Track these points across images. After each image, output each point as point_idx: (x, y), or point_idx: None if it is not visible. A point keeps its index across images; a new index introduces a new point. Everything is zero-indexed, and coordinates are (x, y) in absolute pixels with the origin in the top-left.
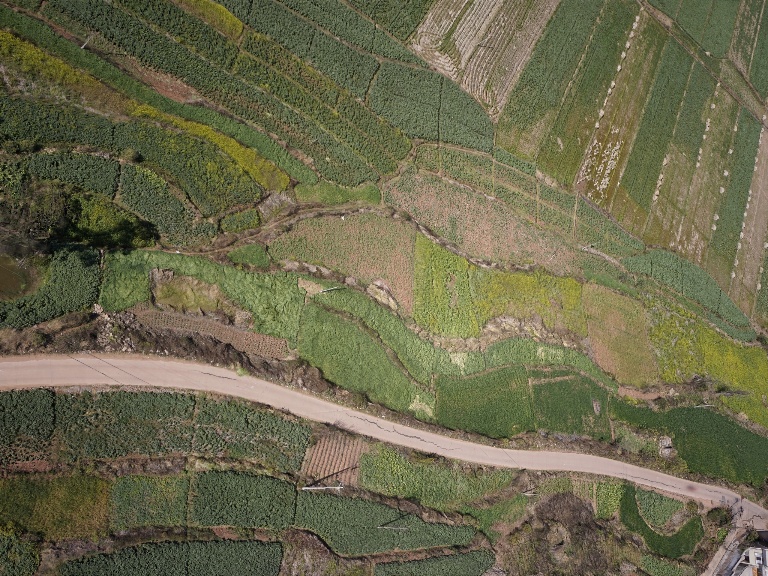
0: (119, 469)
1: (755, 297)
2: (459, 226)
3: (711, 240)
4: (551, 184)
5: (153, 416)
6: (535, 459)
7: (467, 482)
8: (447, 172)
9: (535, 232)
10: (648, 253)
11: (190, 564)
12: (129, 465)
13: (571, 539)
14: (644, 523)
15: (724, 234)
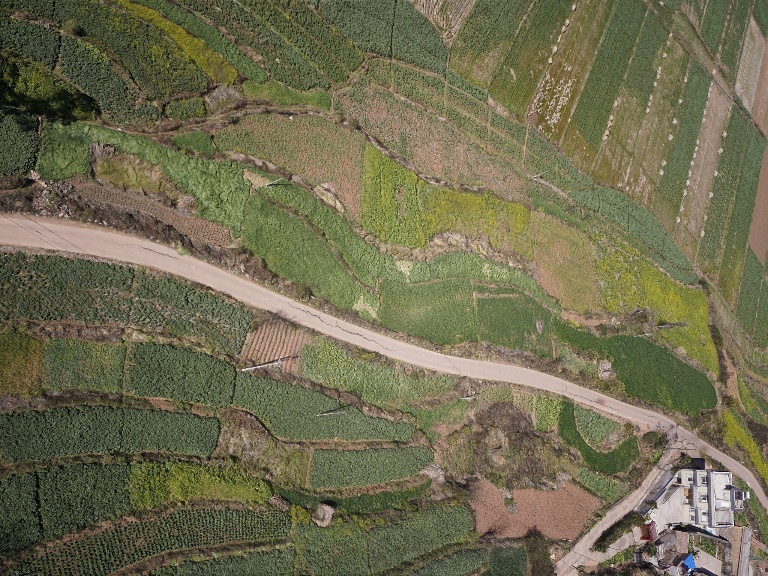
0: (53, 332)
1: (698, 243)
2: (409, 142)
3: (658, 184)
4: (503, 113)
5: (90, 284)
6: (477, 368)
7: (408, 383)
8: (399, 89)
9: (485, 157)
10: (596, 190)
11: (125, 429)
12: (64, 329)
13: (509, 444)
14: (581, 438)
15: (671, 180)
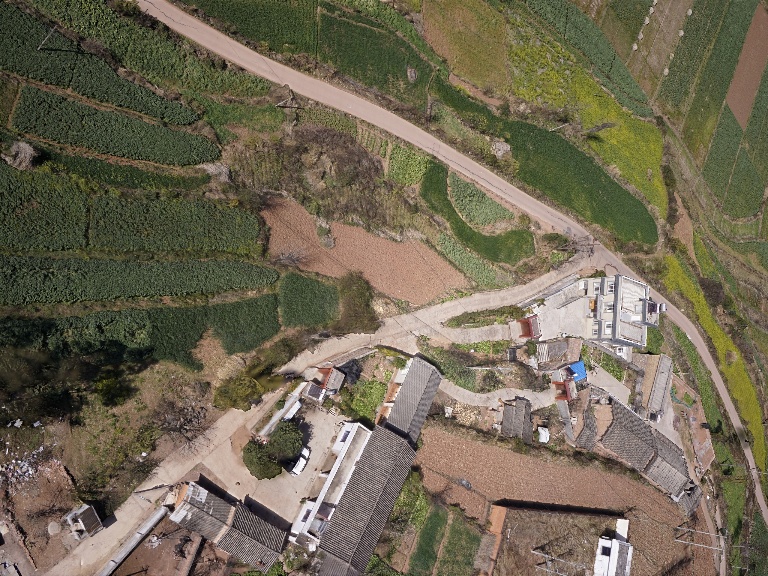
0: None
1: (660, 81)
2: None
3: None
4: None
5: None
6: (308, 85)
7: (199, 68)
8: None
9: None
10: None
11: None
12: None
13: (336, 173)
14: (452, 208)
15: (629, 1)
